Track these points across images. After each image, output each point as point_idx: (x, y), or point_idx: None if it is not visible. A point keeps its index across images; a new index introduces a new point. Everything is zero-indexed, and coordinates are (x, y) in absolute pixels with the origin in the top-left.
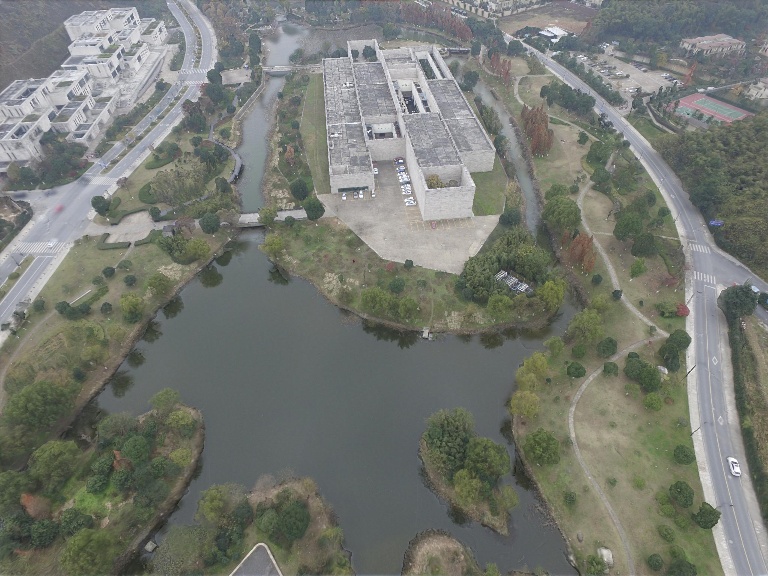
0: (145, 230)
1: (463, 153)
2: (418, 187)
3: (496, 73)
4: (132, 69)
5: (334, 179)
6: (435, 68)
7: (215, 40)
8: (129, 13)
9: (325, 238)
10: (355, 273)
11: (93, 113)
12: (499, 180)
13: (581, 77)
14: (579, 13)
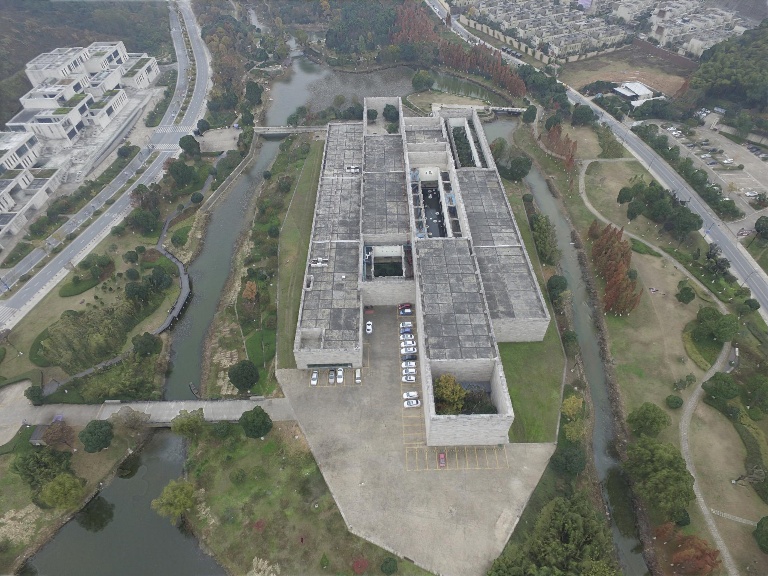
0: (15, 423)
1: (499, 321)
2: (424, 385)
3: (555, 152)
4: (97, 126)
5: (300, 354)
6: (473, 146)
7: (211, 83)
8: (112, 49)
9: (269, 469)
10: (301, 566)
11: (27, 193)
12: (552, 362)
13: (673, 165)
14: (668, 63)
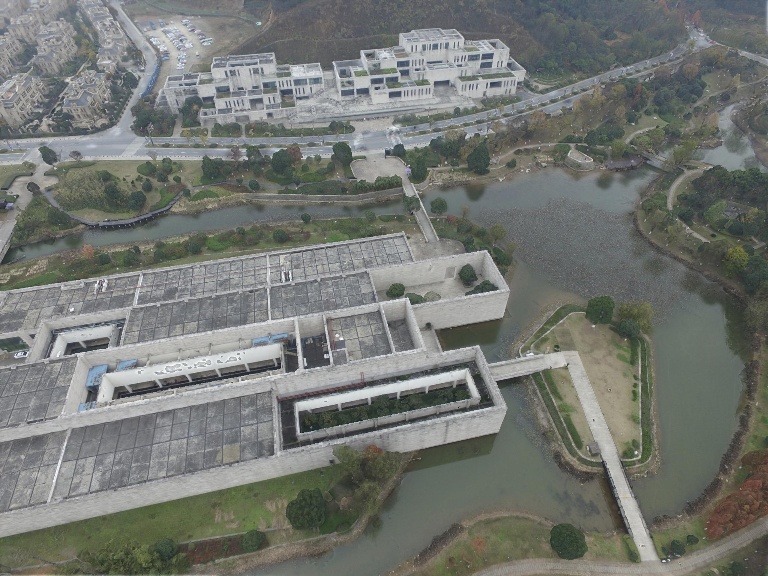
0: (23, 191)
1: None
2: None
3: None
4: (369, 98)
5: None
6: None
7: None
8: (486, 51)
9: None
10: None
11: None
12: None
13: None
14: None
